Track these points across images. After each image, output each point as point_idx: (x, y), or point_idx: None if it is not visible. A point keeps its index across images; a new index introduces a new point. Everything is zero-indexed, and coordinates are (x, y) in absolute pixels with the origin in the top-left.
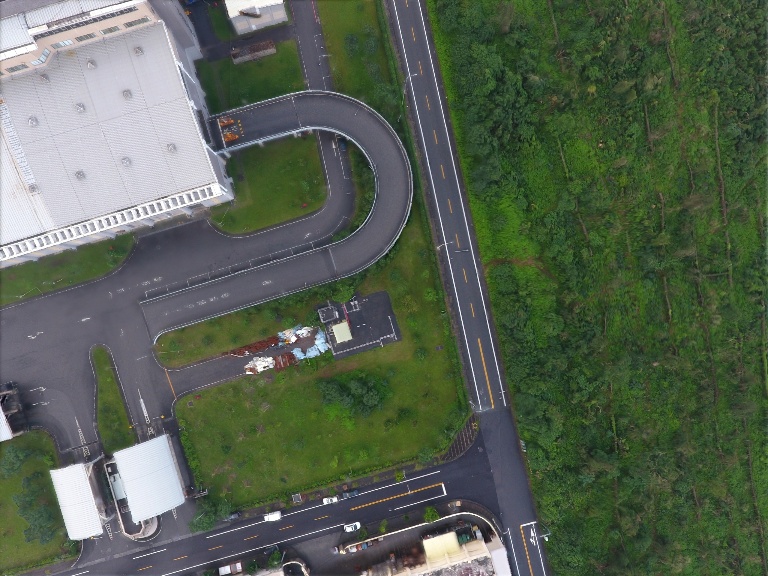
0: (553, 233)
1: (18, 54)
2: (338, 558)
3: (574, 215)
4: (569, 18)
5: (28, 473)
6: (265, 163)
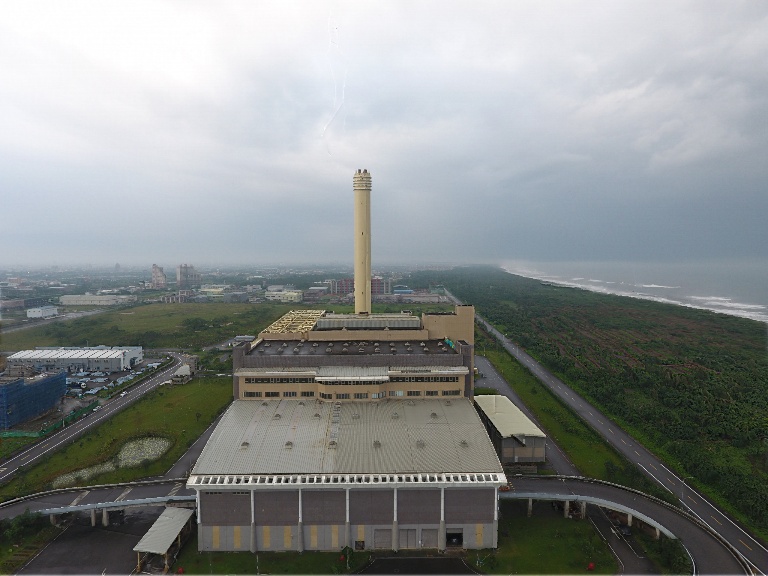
0: None
1: (375, 379)
2: None
3: None
4: None
5: None
6: (533, 528)
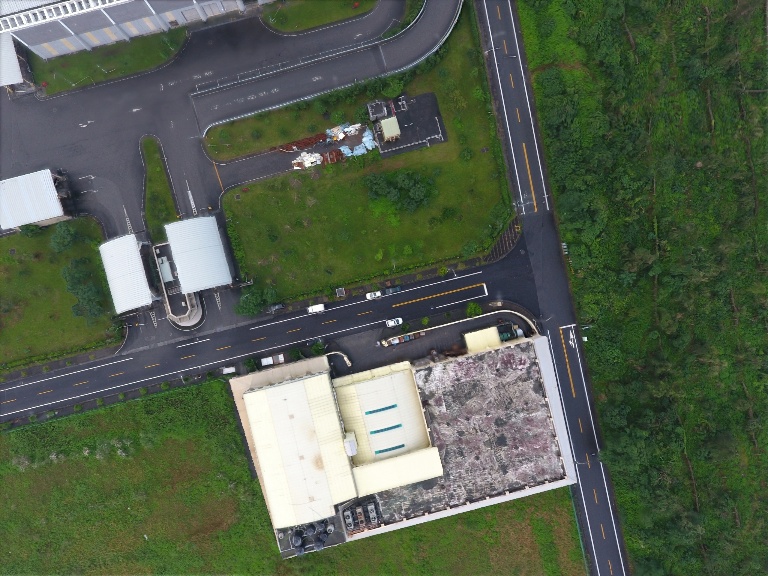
0: (600, 40)
1: None
2: (379, 353)
3: (621, 25)
4: None
5: (75, 259)
6: None
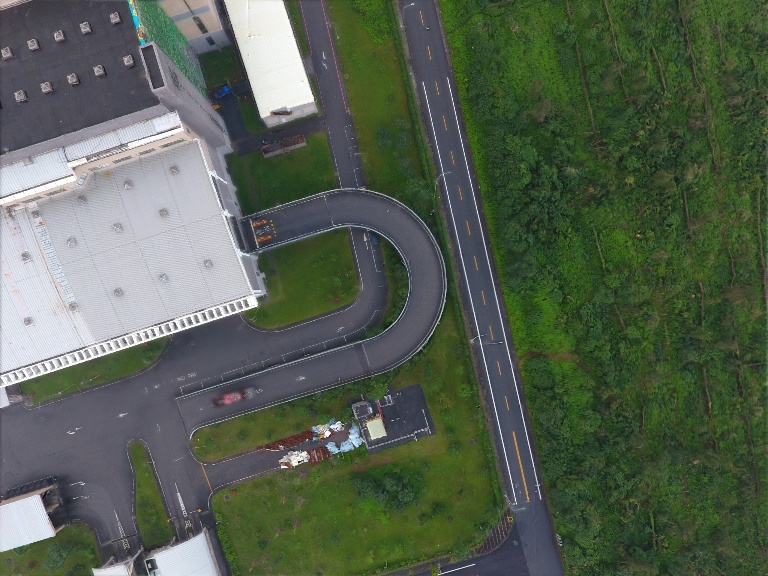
0: (589, 326)
1: None
2: None
3: (611, 306)
4: (605, 105)
5: (70, 565)
6: (297, 257)
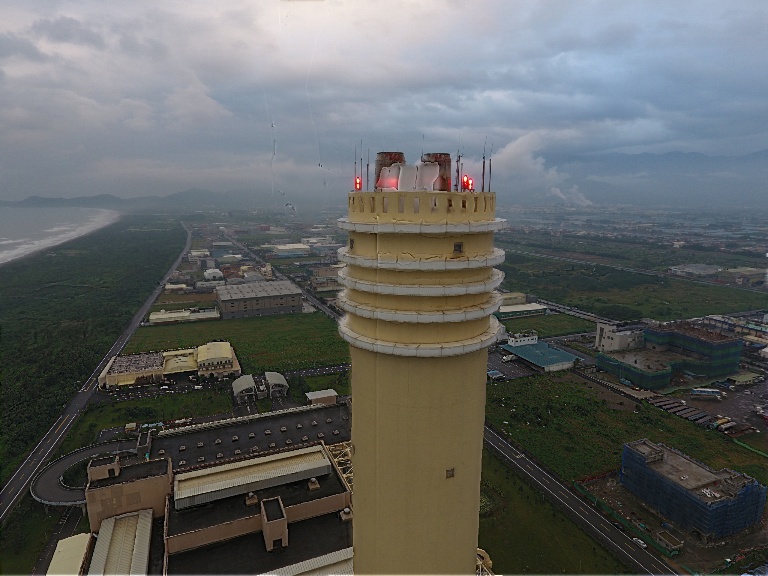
0: None
1: None
2: None
3: None
4: None
5: None
6: None
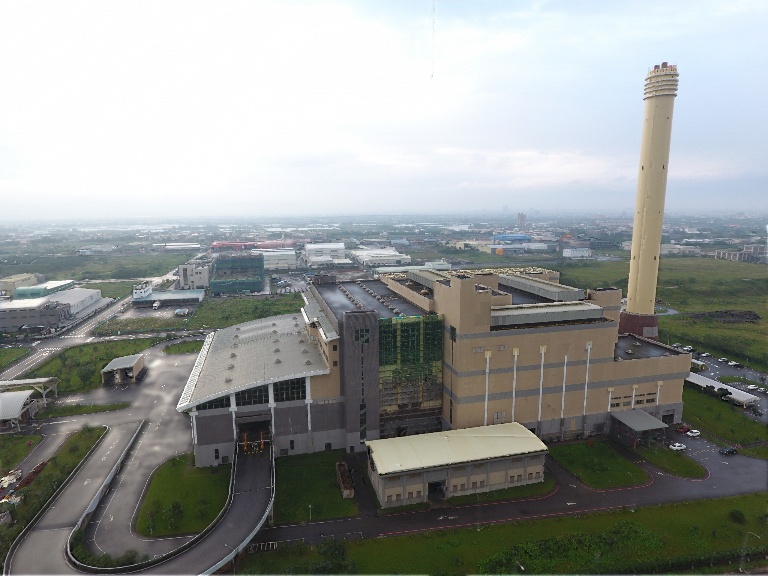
0: None
1: None
2: None
3: None
4: None
5: None
6: (220, 487)
